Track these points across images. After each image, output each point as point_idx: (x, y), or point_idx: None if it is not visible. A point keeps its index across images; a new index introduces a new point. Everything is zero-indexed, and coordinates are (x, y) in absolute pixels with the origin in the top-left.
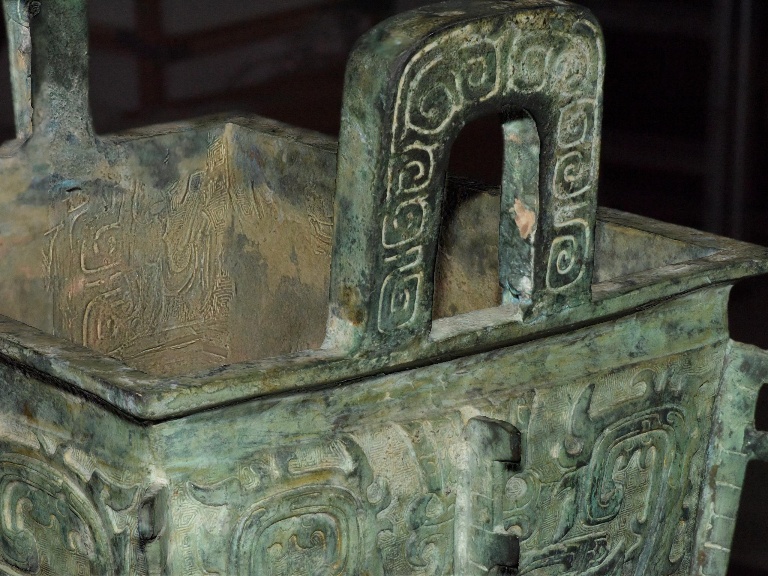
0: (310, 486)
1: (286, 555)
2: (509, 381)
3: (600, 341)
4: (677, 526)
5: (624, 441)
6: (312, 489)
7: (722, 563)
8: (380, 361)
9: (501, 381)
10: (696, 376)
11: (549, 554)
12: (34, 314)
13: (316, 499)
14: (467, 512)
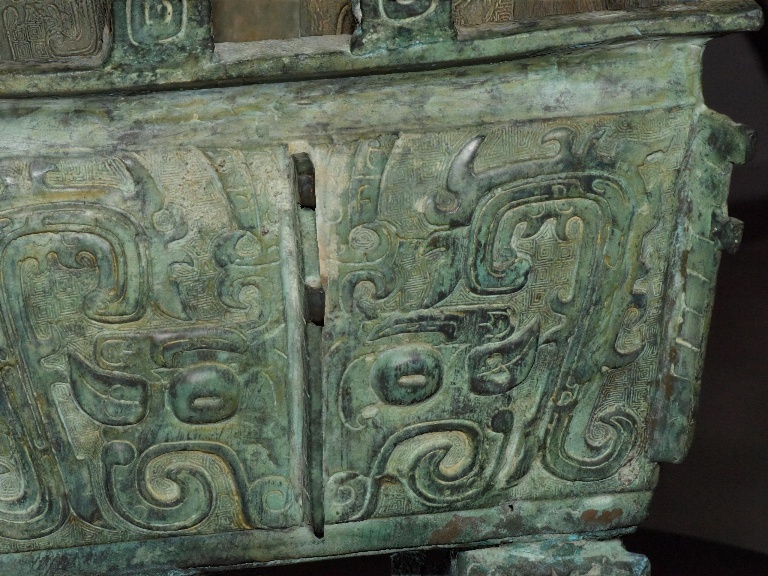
0: (74, 202)
1: (47, 272)
2: (369, 120)
3: (507, 88)
4: (628, 313)
5: (527, 205)
6: (74, 206)
7: (692, 364)
8: (143, 77)
9: (358, 118)
10: (641, 143)
11: (418, 319)
12: (276, 12)
13: (78, 217)
14: (295, 257)
